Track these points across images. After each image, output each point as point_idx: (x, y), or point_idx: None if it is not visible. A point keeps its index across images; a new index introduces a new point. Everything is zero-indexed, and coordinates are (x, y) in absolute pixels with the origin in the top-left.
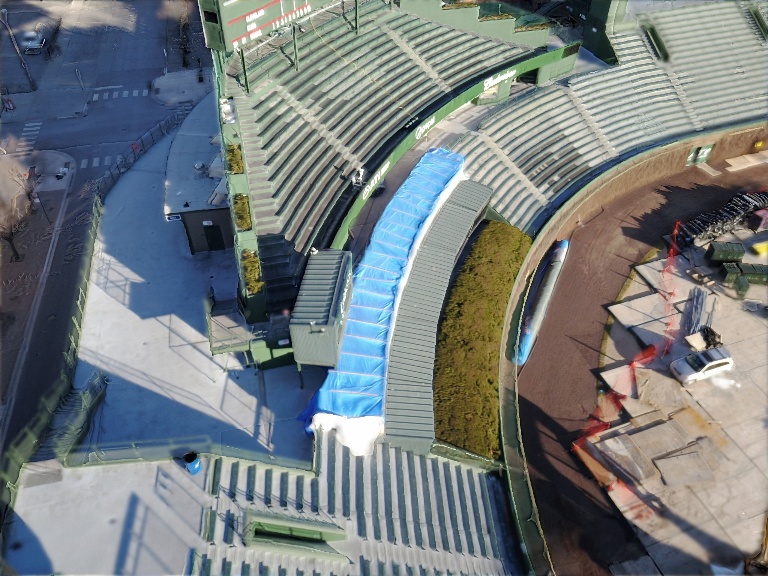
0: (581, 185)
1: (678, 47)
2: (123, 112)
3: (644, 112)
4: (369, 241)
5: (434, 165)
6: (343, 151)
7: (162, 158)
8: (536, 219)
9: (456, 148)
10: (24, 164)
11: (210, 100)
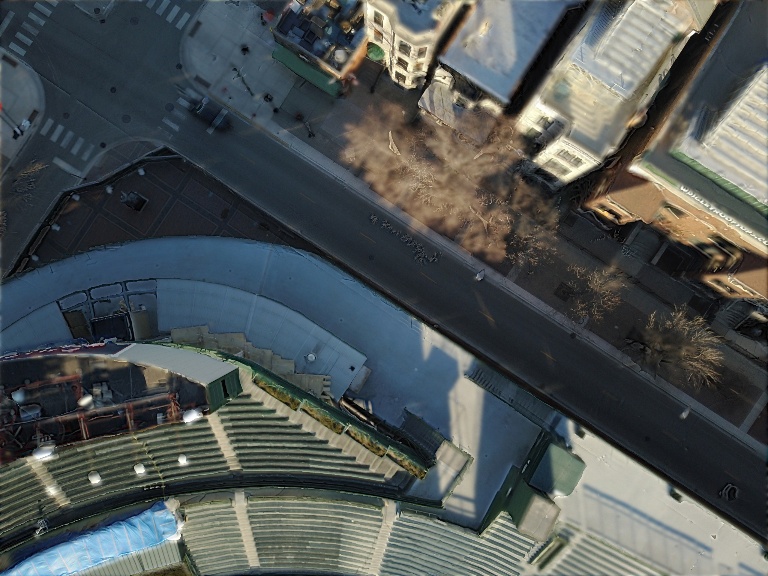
0: (308, 571)
1: (567, 572)
2: (134, 51)
3: (449, 574)
4: (13, 567)
5: (136, 530)
6: (56, 491)
7: (3, 307)
8: (229, 571)
9: (199, 506)
10: (2, 82)
11: (36, 320)
